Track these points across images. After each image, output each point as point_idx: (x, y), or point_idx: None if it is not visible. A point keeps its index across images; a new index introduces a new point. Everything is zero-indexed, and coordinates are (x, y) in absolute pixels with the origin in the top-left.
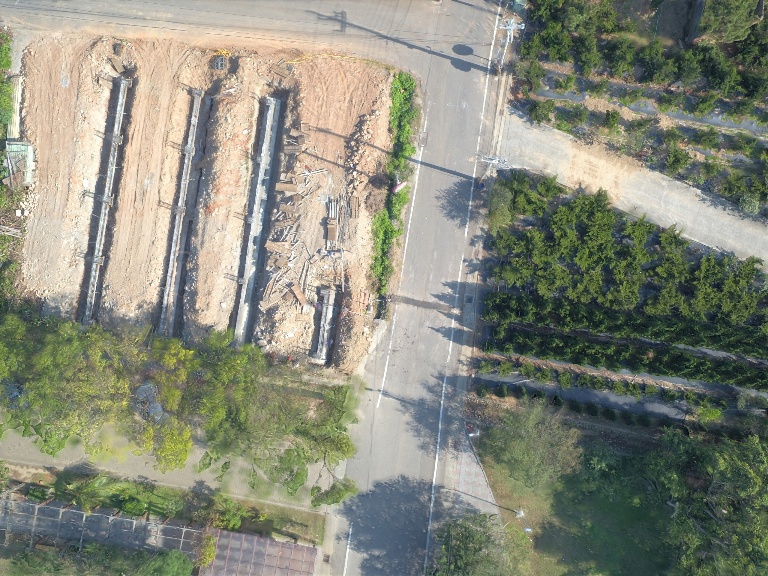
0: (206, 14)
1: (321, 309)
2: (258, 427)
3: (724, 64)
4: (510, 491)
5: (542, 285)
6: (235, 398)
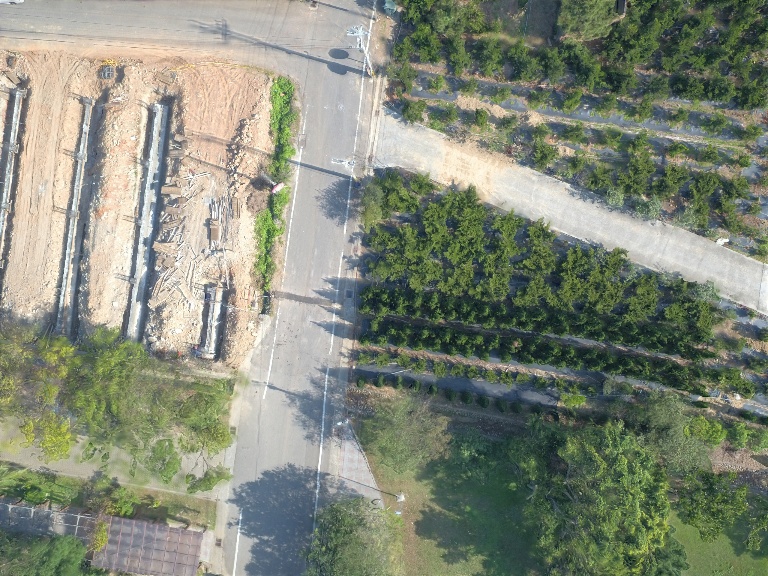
0: (93, 26)
1: (209, 306)
2: (131, 419)
3: (587, 61)
4: (391, 477)
5: (415, 279)
6: (106, 392)
